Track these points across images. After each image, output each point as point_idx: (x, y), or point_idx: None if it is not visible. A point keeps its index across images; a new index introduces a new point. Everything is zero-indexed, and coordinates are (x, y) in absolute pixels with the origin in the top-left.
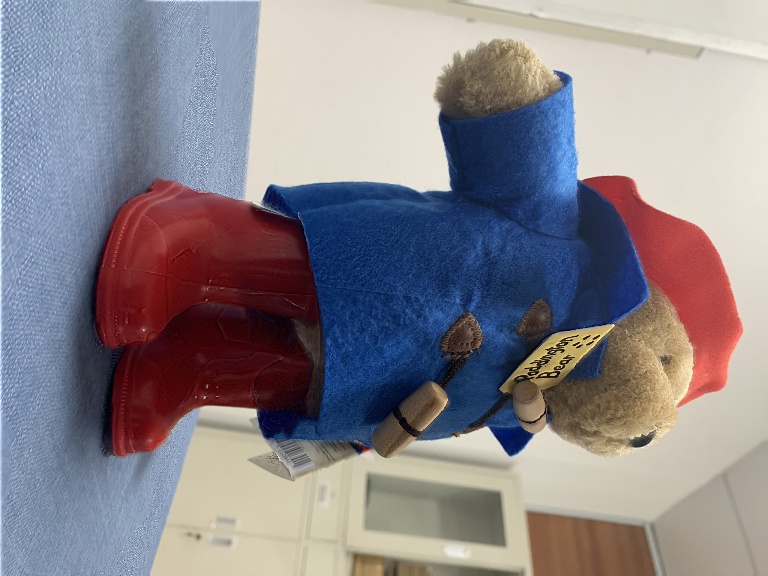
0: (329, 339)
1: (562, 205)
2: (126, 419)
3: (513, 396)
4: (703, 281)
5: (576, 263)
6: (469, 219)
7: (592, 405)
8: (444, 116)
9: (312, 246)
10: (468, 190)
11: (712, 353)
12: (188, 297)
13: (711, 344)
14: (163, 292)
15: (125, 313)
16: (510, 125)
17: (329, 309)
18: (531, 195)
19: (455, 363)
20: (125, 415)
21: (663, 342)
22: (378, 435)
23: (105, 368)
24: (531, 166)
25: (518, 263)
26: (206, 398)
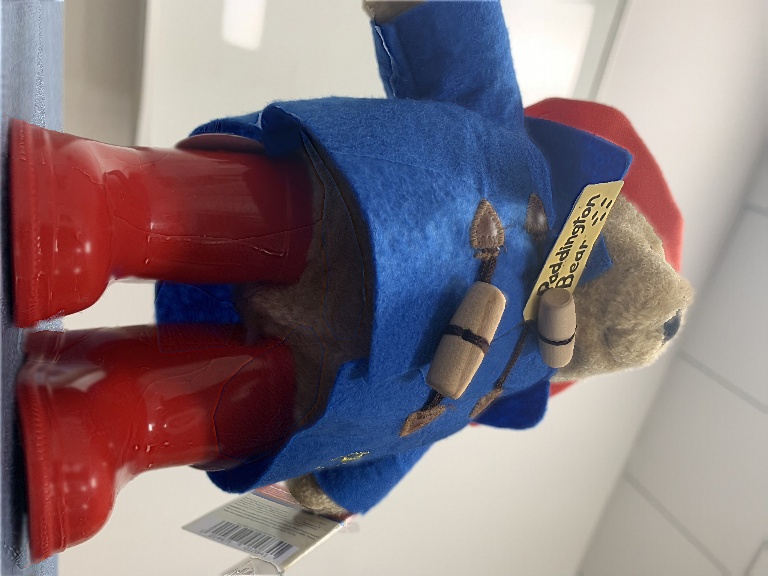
0: (369, 212)
1: (517, 98)
2: (49, 468)
3: (545, 308)
4: (643, 172)
5: (544, 161)
6: (447, 106)
7: (621, 295)
8: (381, 19)
9: (304, 119)
10: (425, 95)
11: (670, 249)
12: (124, 250)
13: (668, 238)
14: (104, 208)
15: (53, 231)
16: (461, 0)
17: (357, 176)
18: (494, 80)
19: (487, 266)
20: (46, 461)
21: (642, 230)
22: (439, 369)
23: (3, 377)
24: (488, 46)
25: (506, 150)
26: (150, 450)
